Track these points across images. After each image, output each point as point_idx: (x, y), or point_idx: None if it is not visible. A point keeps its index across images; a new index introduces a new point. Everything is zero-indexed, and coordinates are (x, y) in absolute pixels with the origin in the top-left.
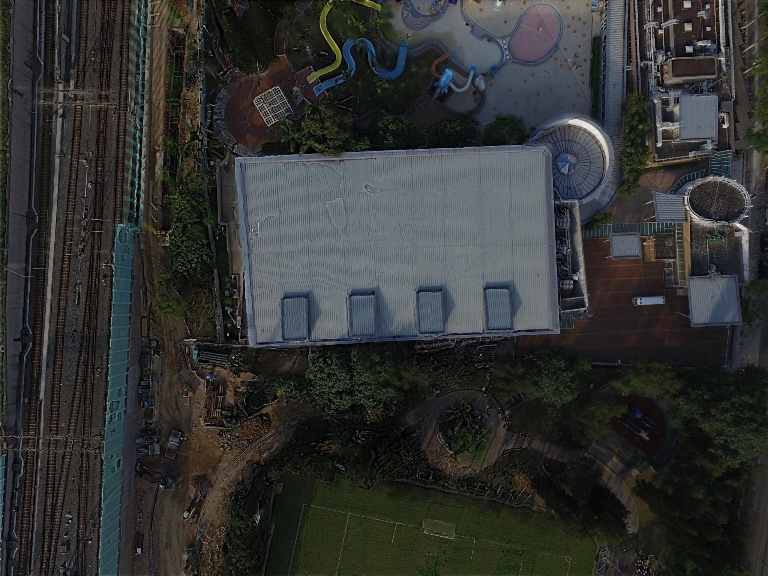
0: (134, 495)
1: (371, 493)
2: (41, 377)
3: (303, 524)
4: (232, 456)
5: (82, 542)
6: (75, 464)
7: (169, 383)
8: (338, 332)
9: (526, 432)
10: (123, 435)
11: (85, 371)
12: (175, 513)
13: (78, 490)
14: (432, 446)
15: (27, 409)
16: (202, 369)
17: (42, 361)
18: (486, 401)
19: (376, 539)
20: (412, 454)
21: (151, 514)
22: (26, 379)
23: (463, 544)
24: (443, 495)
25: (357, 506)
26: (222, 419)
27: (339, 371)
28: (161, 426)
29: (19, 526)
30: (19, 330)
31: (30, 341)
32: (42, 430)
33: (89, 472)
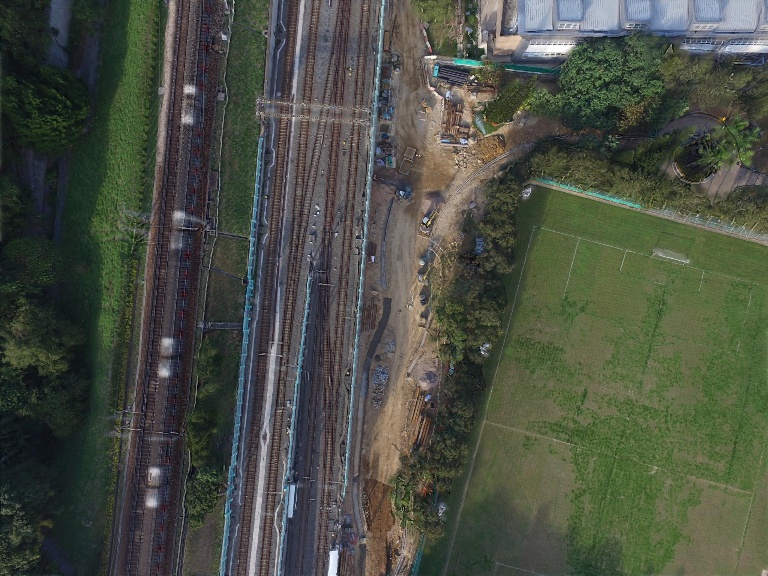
0: (370, 205)
1: (602, 219)
2: (294, 73)
3: (533, 246)
4: (466, 175)
5: (328, 234)
6: (325, 158)
7: (406, 101)
8: (605, 27)
9: (761, 169)
10: (374, 131)
11: (337, 70)
12: (407, 227)
13: (326, 184)
14: (667, 175)
15: (279, 103)
16: (440, 88)
17: (295, 57)
18: (723, 134)
19: (605, 265)
20: (650, 177)
21: (384, 226)
22: (279, 74)
23: (692, 275)
24: (674, 226)
25: (588, 231)
26: (459, 136)
27: (616, 52)
28: (396, 142)
29: (269, 213)
30: (275, 24)
31: (284, 37)
32: (293, 124)
33: (337, 167)
